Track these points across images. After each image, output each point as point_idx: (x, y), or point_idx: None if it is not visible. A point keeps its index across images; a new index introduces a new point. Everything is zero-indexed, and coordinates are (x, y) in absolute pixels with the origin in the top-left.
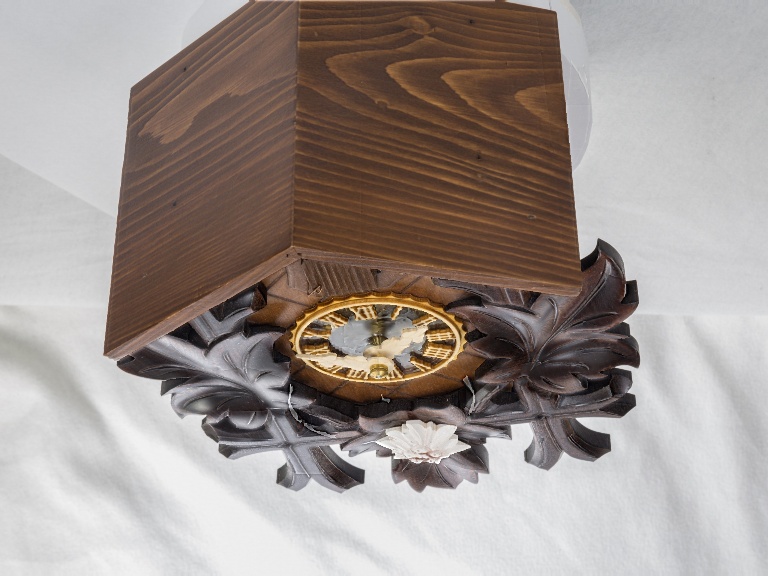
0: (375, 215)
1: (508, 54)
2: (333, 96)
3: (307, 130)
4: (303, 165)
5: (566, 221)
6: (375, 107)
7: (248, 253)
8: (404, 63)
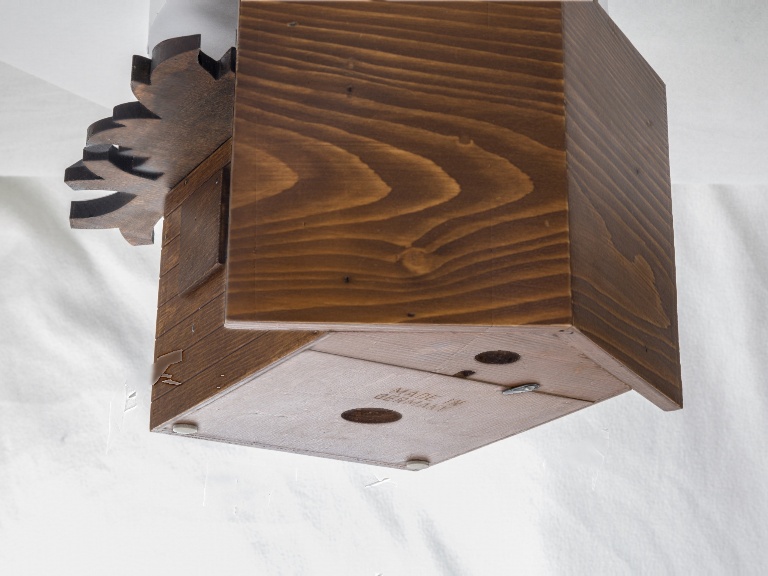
0: (473, 3)
1: (301, 239)
2: (523, 141)
3: (552, 93)
4: (554, 50)
5: (252, 25)
6: (473, 135)
7: (587, 7)
8: (438, 201)
